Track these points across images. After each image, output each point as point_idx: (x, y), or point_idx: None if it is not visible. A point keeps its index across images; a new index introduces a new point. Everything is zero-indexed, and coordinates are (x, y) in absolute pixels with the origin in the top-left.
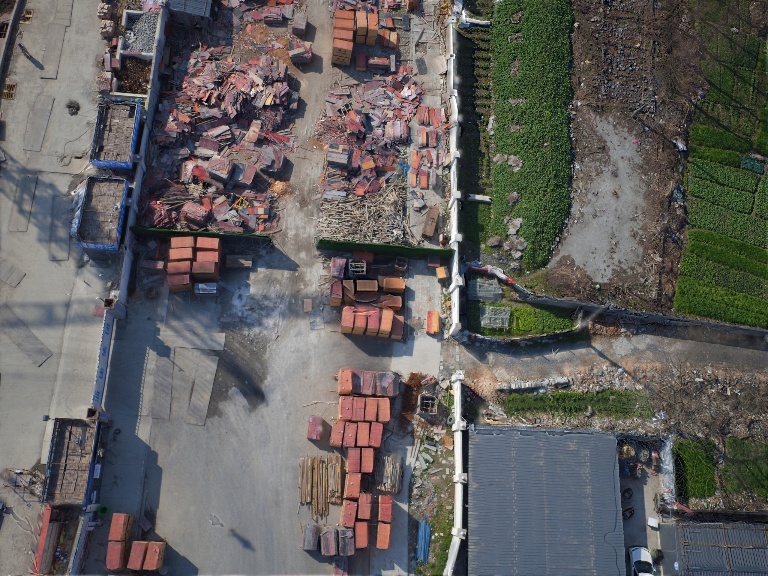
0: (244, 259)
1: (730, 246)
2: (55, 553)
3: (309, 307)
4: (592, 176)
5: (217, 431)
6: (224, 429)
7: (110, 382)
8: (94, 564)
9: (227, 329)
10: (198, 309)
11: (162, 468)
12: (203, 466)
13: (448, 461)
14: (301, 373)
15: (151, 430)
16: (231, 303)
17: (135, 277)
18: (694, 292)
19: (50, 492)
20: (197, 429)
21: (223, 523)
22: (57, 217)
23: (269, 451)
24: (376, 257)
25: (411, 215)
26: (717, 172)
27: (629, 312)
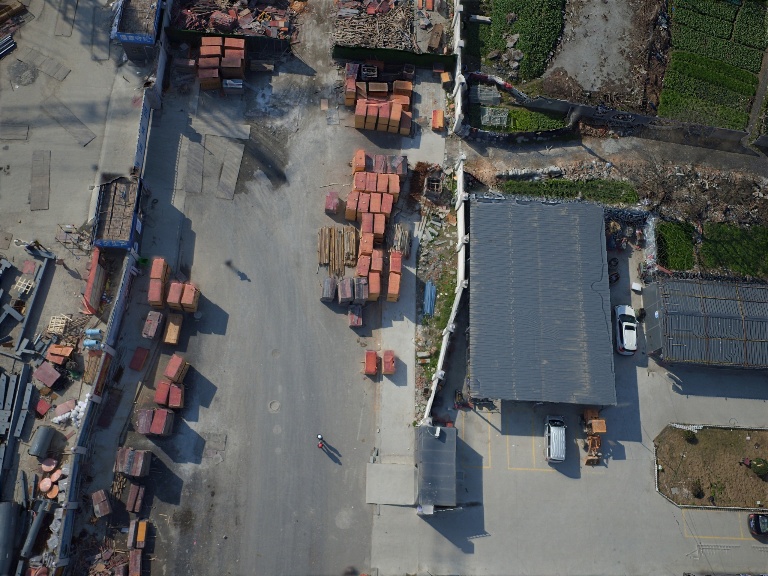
0: (267, 63)
1: (710, 65)
2: (102, 296)
3: (326, 106)
4: (583, 2)
5: (244, 205)
6: (250, 203)
7: (148, 161)
8: (137, 307)
9: (252, 122)
10: (226, 104)
11: (195, 233)
12: (232, 232)
13: (452, 235)
14: (319, 160)
15: (185, 201)
16: (255, 101)
17: (169, 75)
18: (676, 102)
19: (98, 236)
20: (226, 202)
21: (250, 279)
22: (98, 24)
23: (291, 222)
24: (386, 67)
25: (418, 32)
26: (699, 3)
27: (616, 113)
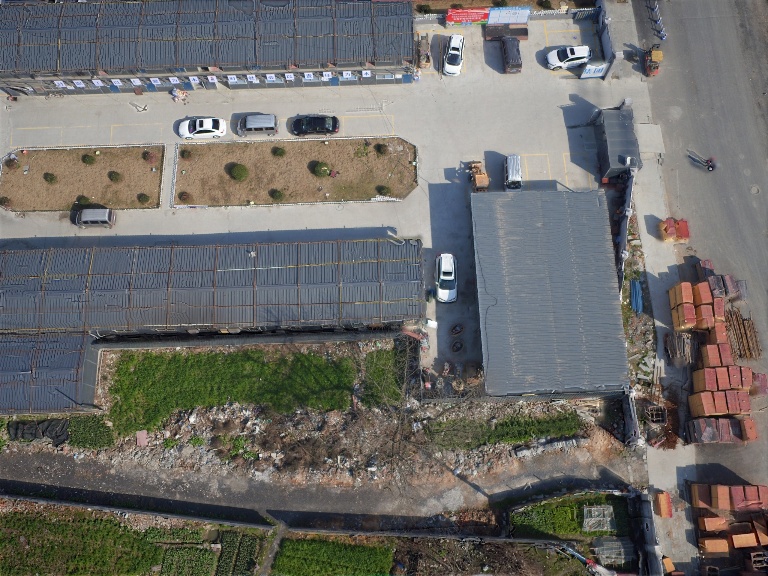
0: None
1: None
2: None
3: None
4: None
5: None
6: None
7: None
8: None
9: None
10: None
11: None
12: None
13: None
14: None
15: None
16: None
17: None
18: (369, 575)
19: None
20: None
21: None
22: None
23: None
24: None
25: None
26: None
27: None
